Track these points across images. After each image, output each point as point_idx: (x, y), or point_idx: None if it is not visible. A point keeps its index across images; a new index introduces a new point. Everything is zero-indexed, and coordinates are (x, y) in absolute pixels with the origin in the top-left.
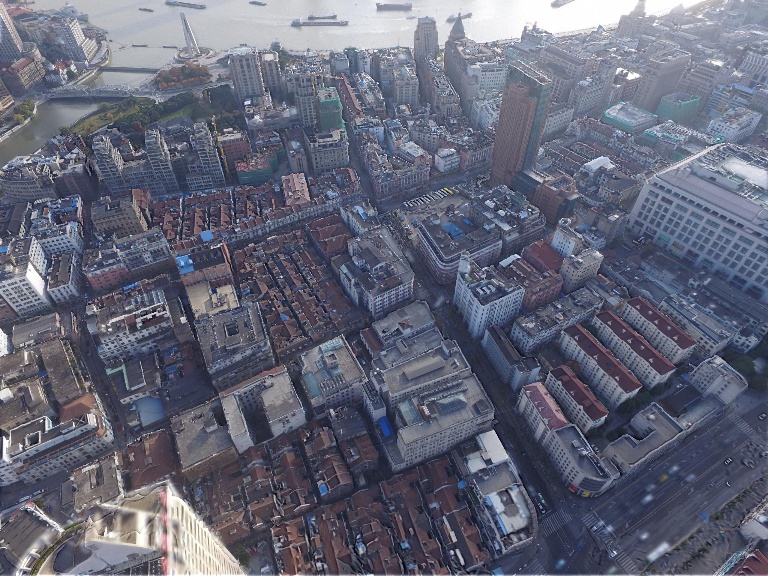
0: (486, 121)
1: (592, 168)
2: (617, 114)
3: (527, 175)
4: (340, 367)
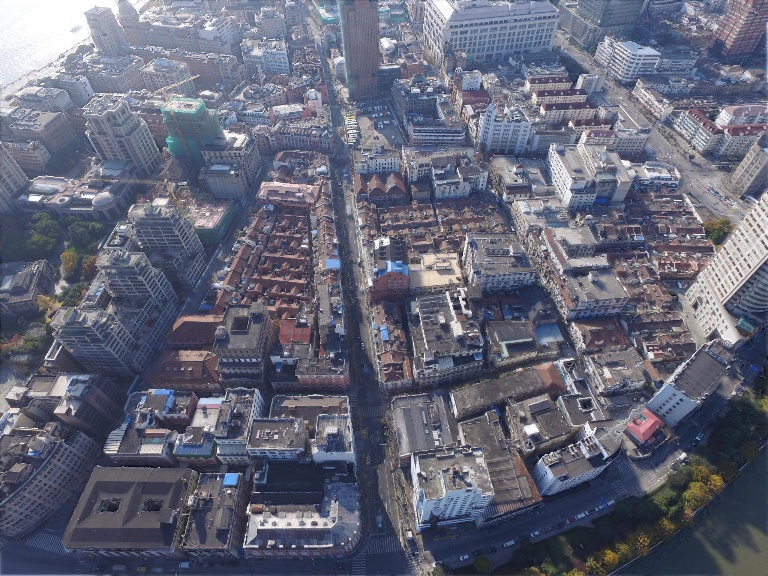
0: (280, 64)
1: (393, 47)
2: (332, 15)
3: (385, 69)
4: None
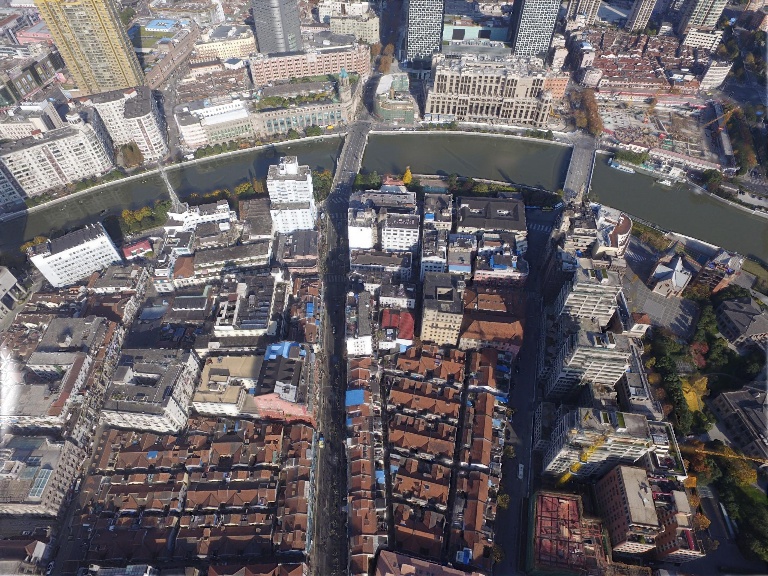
0: None
1: None
2: None
3: None
4: (5, 480)
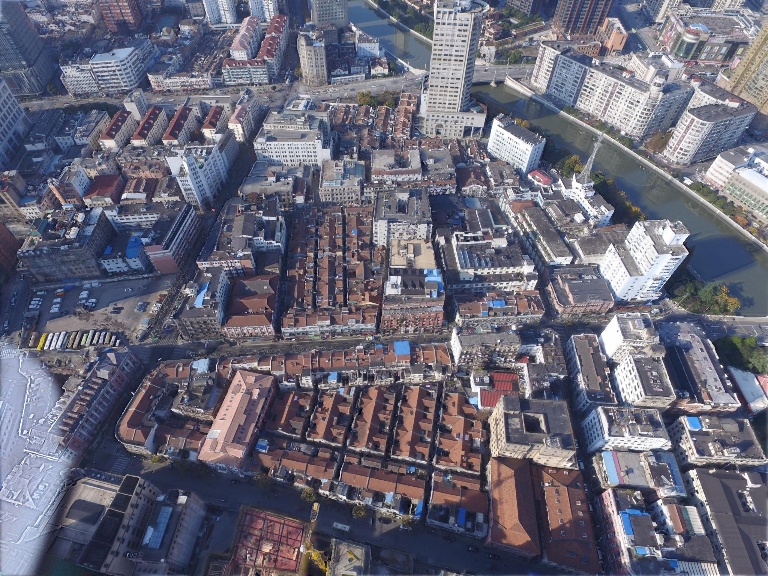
0: None
1: None
2: None
3: None
4: None
